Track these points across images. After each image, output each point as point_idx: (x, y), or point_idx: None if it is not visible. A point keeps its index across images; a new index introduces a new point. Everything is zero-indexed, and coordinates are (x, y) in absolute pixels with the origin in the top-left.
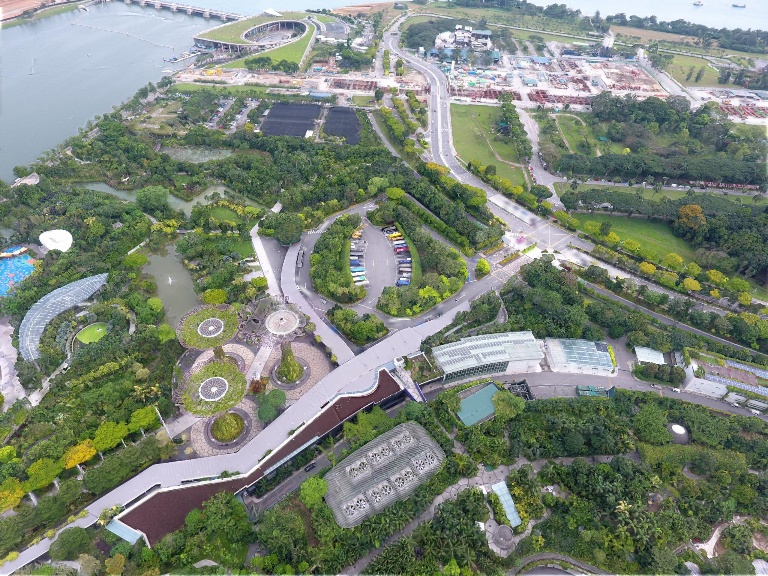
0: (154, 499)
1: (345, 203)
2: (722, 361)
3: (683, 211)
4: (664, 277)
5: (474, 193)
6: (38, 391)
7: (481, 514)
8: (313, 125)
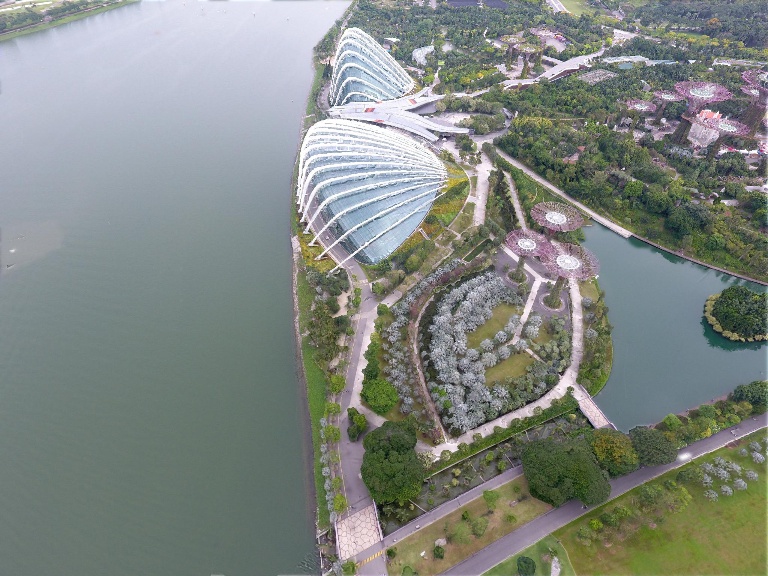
0: (513, 86)
1: (526, 26)
2: (729, 59)
3: (709, 21)
4: (700, 43)
5: (593, 20)
6: (437, 73)
7: (638, 82)
8: (479, 4)
